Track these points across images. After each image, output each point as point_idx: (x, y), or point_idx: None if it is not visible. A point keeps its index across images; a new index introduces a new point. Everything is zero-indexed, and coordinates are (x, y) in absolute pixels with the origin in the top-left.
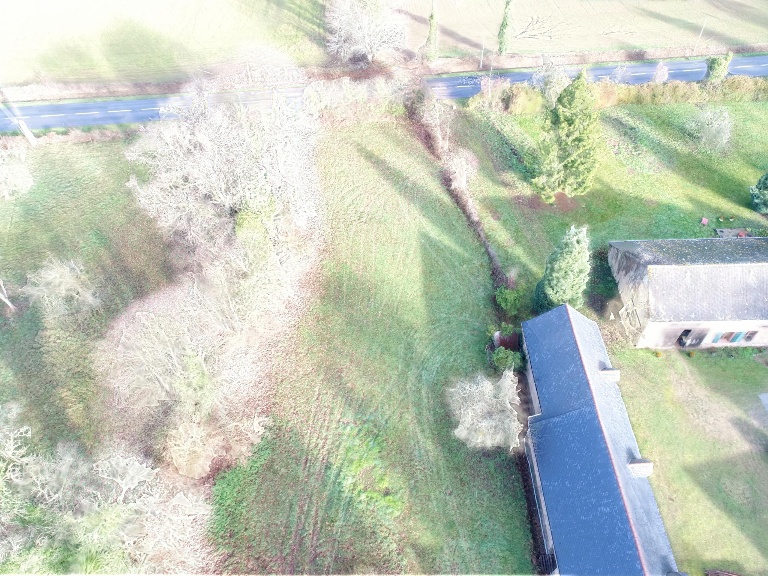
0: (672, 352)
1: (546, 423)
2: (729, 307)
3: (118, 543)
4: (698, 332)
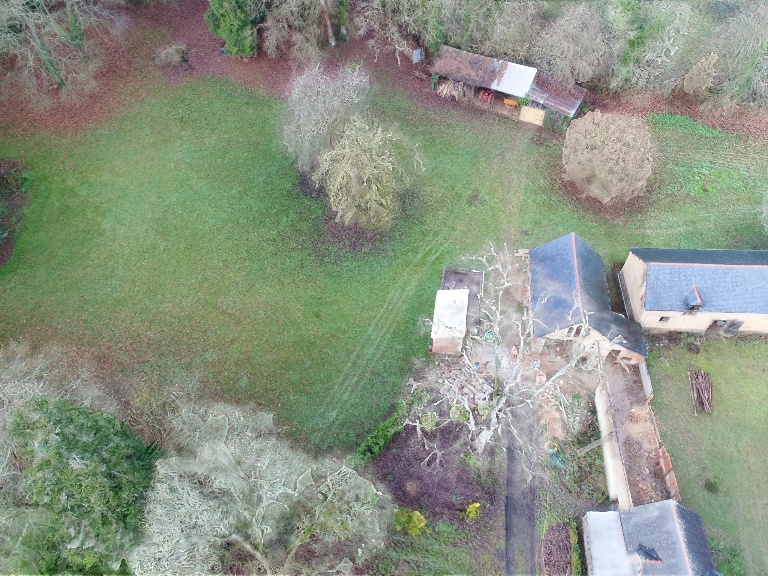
0: None
1: None
2: None
3: (647, 28)
4: None
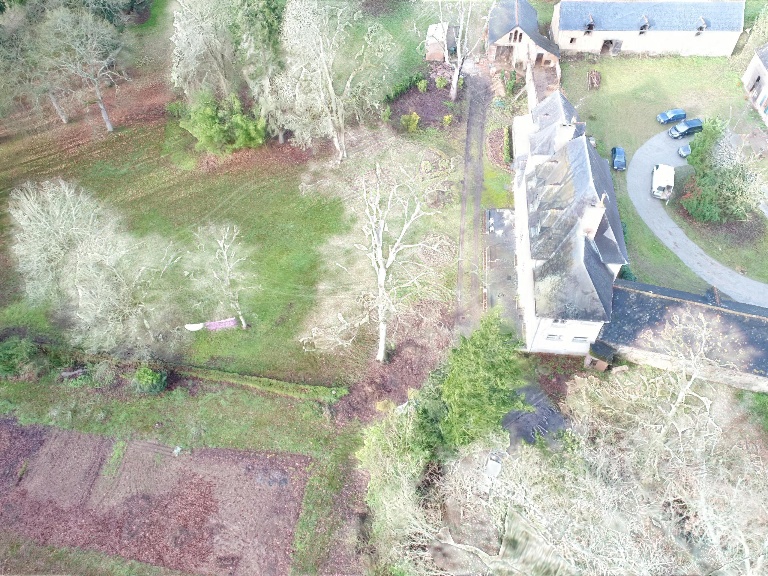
0: (745, 93)
1: None
2: None
3: None
4: None
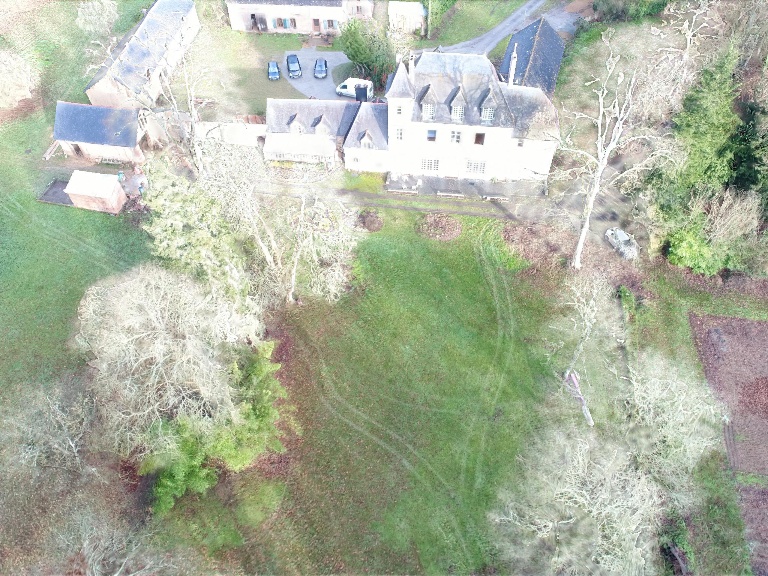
0: (252, 33)
1: None
2: None
3: None
4: (260, 17)
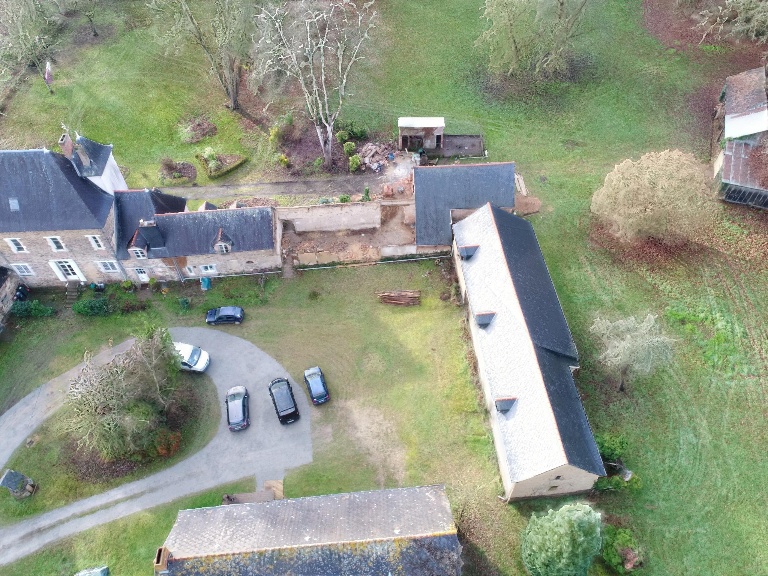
0: None
1: (566, 351)
2: (343, 507)
3: None
4: None
